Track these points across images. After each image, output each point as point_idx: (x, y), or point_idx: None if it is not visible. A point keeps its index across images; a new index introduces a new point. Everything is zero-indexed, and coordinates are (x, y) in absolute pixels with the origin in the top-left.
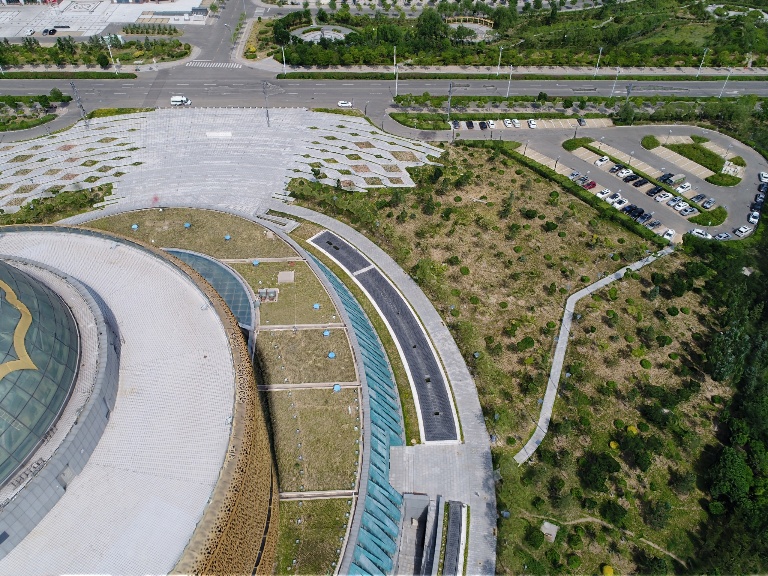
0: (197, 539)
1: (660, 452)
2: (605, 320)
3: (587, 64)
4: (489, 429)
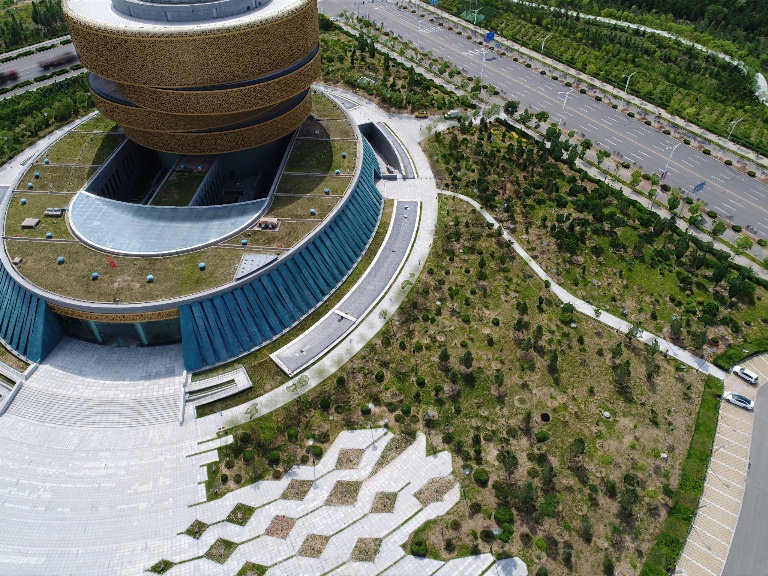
0: None
1: None
2: None
3: None
4: None
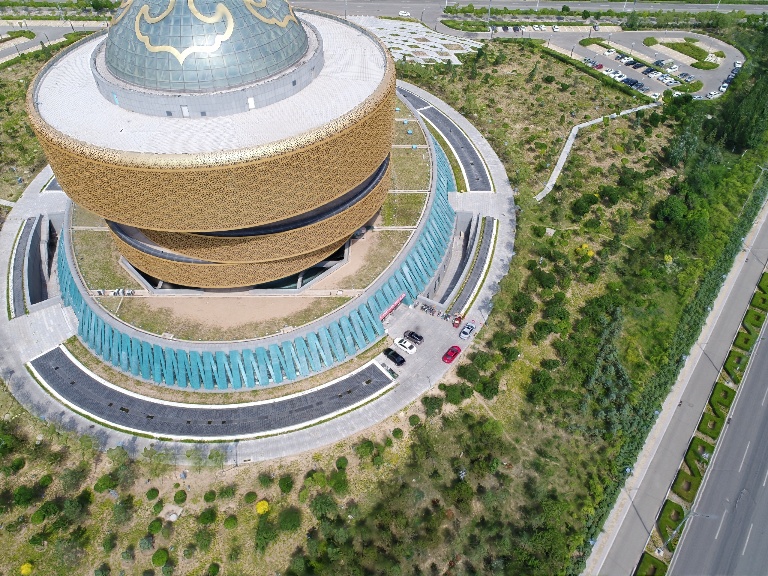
0: (379, 89)
1: (628, 201)
2: (599, 138)
3: None
4: (513, 187)
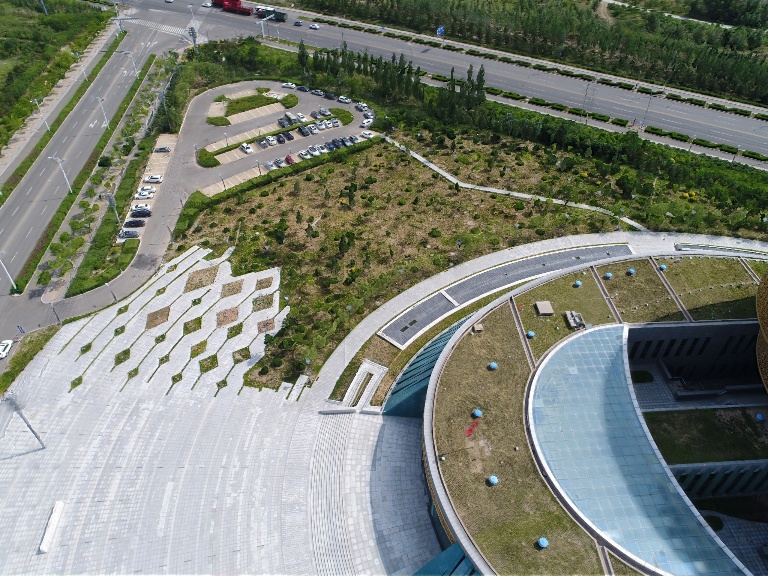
0: None
1: None
2: (484, 172)
3: (10, 132)
4: (609, 231)
